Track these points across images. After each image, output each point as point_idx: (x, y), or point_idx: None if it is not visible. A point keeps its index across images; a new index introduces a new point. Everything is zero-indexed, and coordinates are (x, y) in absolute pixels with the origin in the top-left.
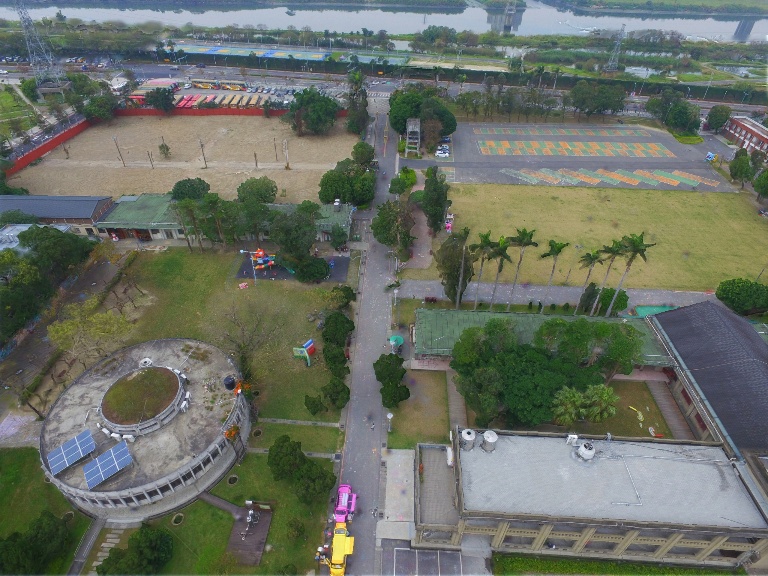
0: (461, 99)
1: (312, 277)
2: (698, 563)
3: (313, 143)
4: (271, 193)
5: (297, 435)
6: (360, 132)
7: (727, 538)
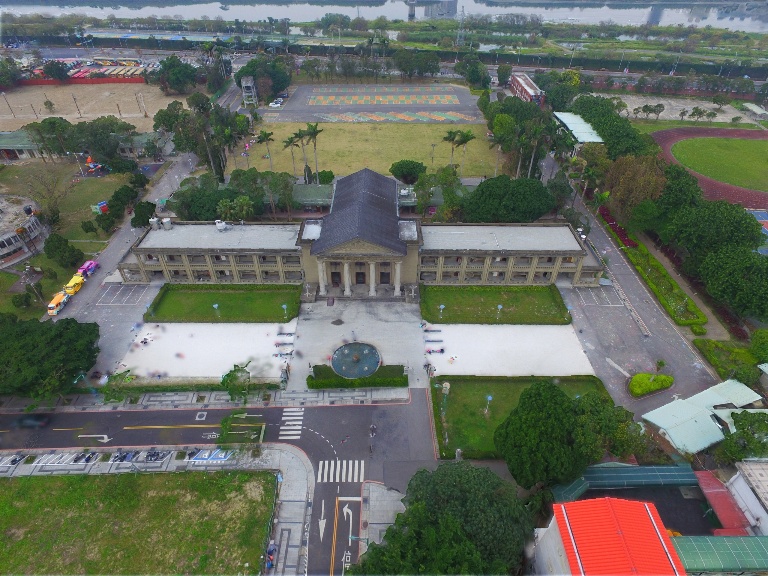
0: (304, 65)
1: (121, 171)
2: None
3: None
4: None
5: (77, 246)
6: (216, 91)
7: (280, 258)
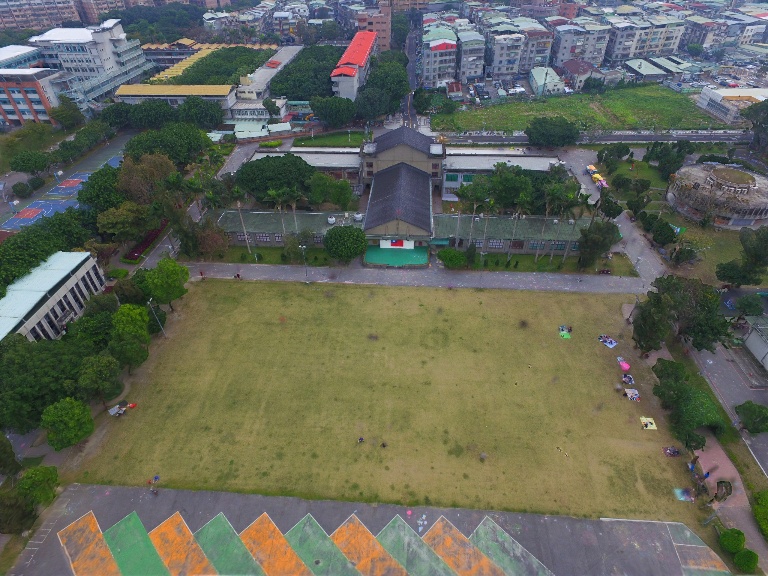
0: None
1: None
2: None
3: None
4: None
5: None
6: None
7: None
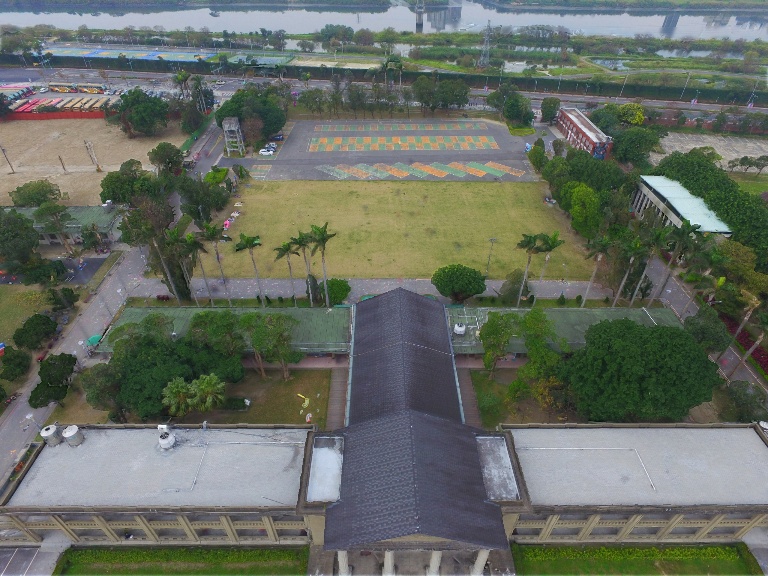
0: (303, 97)
1: (39, 280)
2: (272, 543)
3: (142, 145)
4: (49, 196)
5: None
6: (192, 132)
7: (267, 517)
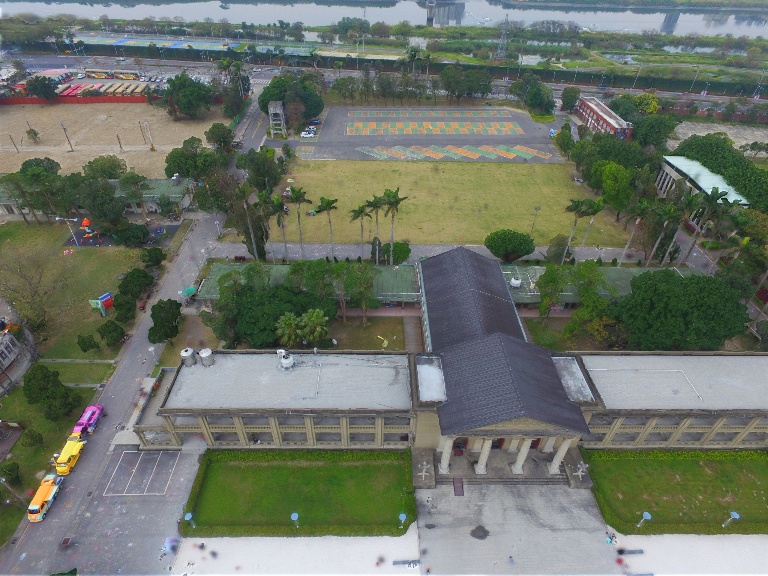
0: (336, 84)
1: (128, 241)
2: (378, 448)
3: (187, 127)
4: (118, 170)
5: (71, 371)
6: (234, 116)
7: (381, 420)
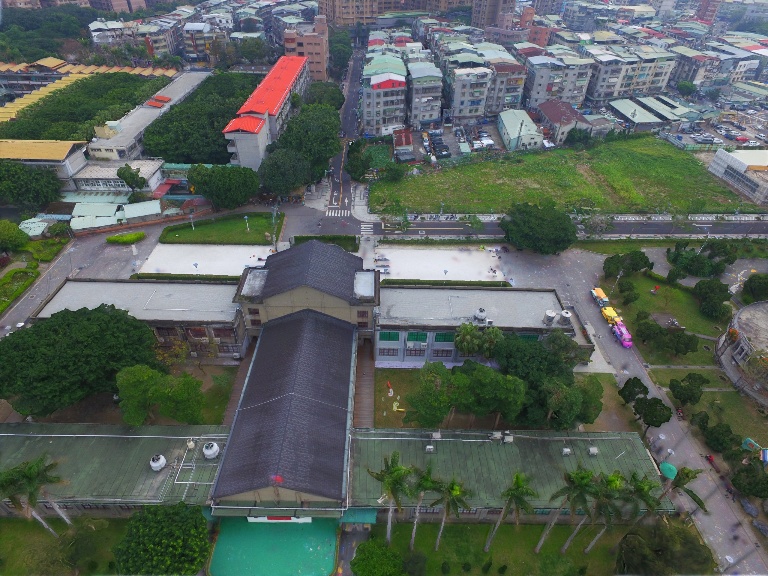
0: None
1: None
2: None
3: None
4: None
5: None
6: None
7: None
